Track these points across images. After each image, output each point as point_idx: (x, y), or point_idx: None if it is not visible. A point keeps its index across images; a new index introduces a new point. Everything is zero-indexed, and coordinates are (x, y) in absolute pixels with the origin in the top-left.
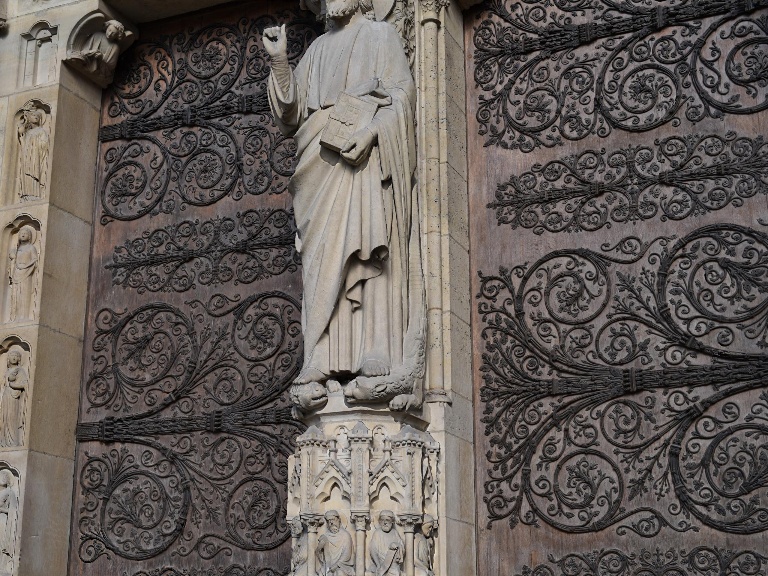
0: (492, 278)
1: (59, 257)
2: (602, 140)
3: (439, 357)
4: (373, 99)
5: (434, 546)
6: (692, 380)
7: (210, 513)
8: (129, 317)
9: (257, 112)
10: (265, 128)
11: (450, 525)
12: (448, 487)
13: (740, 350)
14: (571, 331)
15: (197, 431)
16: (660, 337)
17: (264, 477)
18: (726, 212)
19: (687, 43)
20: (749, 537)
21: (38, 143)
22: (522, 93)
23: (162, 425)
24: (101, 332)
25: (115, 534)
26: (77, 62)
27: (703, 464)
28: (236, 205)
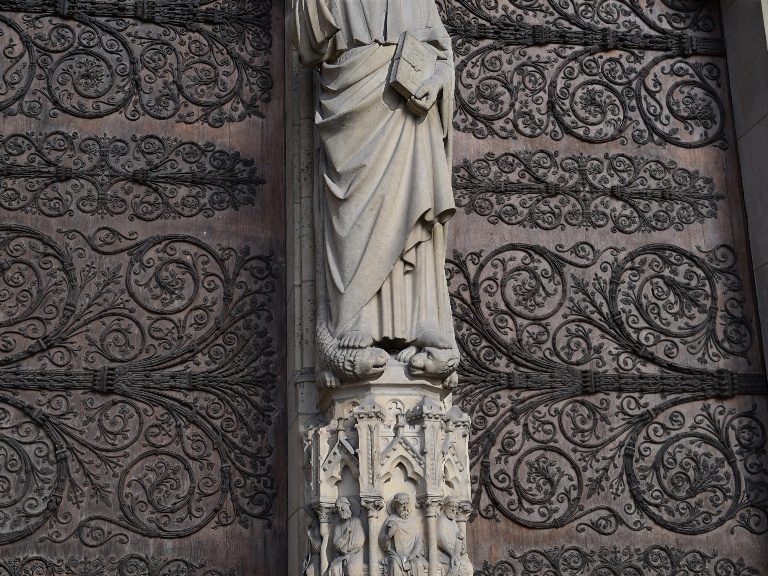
0: (446, 260)
1: None
2: (555, 143)
3: None
4: (433, 49)
5: None
6: (646, 387)
7: (97, 491)
8: None
9: (160, 23)
10: (171, 44)
11: None
12: None
13: (684, 363)
14: (528, 326)
15: (77, 389)
16: (613, 342)
17: (174, 451)
18: (669, 234)
19: (633, 69)
20: (695, 537)
21: None
22: (474, 78)
23: (26, 378)
24: None
25: None
26: None
27: (655, 467)
28: (131, 126)
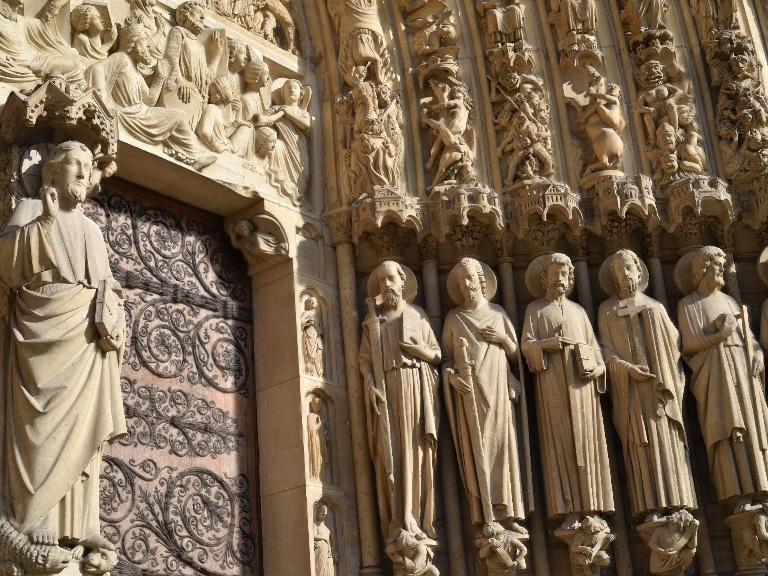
0: None
1: None
2: (135, 372)
3: None
4: (117, 296)
5: None
6: None
7: None
8: None
9: None
10: None
11: None
12: None
13: (211, 568)
14: (106, 527)
15: None
16: (164, 547)
17: None
18: (207, 460)
19: None
20: None
21: None
22: None
23: None
24: None
25: None
26: None
27: None
28: None
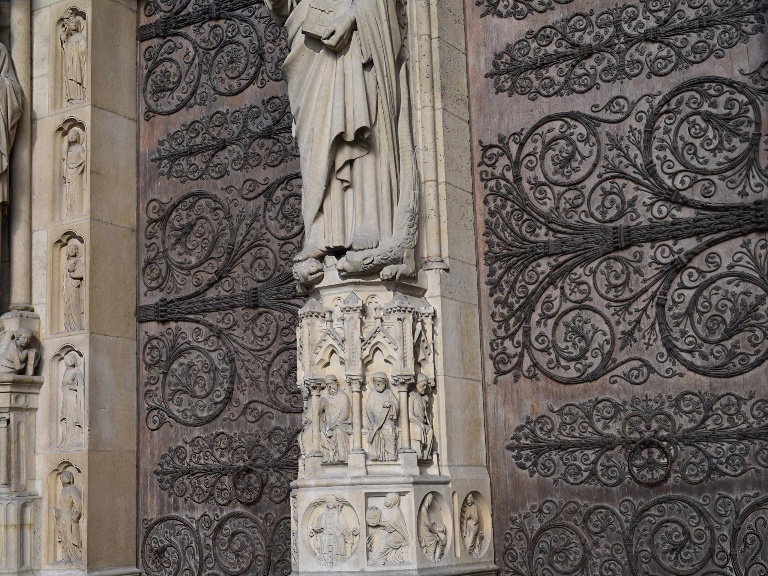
0: (491, 146)
1: (105, 155)
2: (590, 1)
3: (435, 227)
4: None
5: (432, 402)
6: (676, 233)
7: (253, 381)
8: (174, 206)
9: None
10: None
11: (450, 382)
12: (446, 348)
13: (722, 201)
14: (565, 193)
15: (238, 307)
16: (647, 193)
17: None
18: (708, 65)
19: None
20: (730, 380)
21: (78, 49)
22: None
23: (208, 304)
24: (151, 221)
25: (175, 404)
26: None
27: (687, 313)
28: (261, 93)
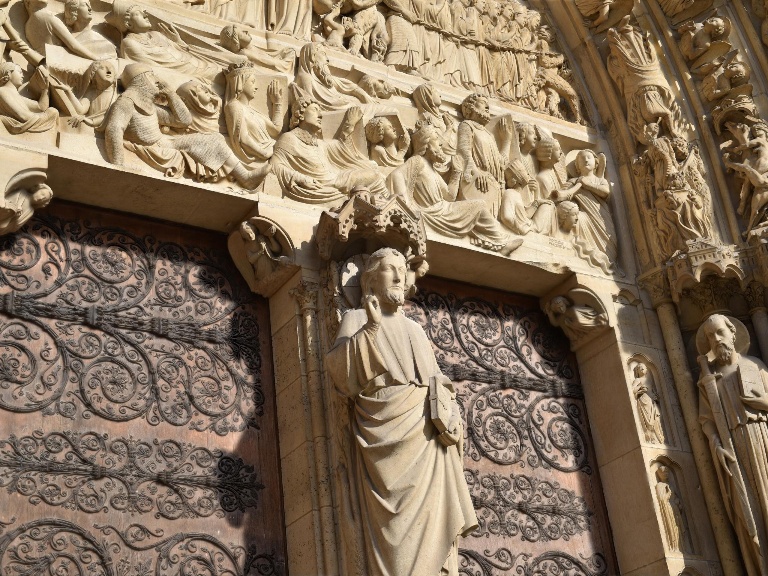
0: None
1: None
2: (475, 463)
3: None
4: None
5: None
6: None
7: None
8: (22, 530)
9: (172, 339)
10: (182, 358)
11: None
12: None
13: None
14: None
15: None
16: None
17: None
18: (560, 543)
19: (523, 405)
20: None
21: None
22: None
23: None
24: None
25: None
26: (8, 214)
27: None
28: (152, 430)
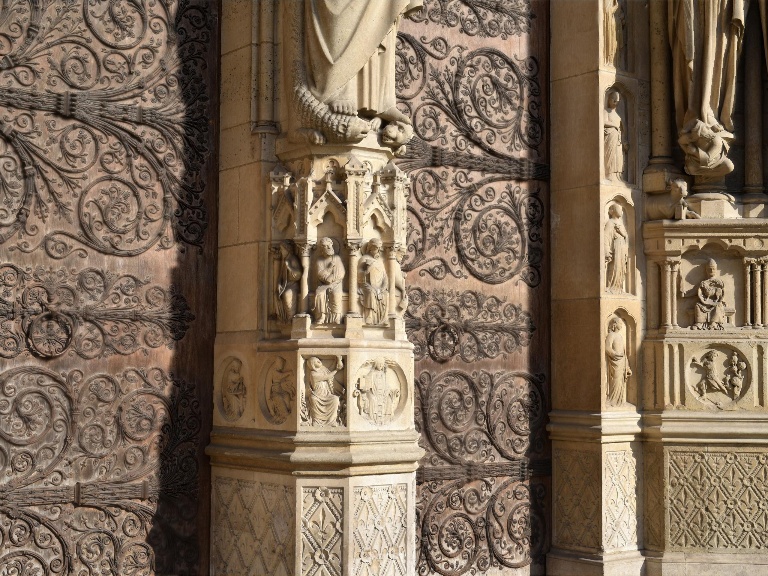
0: None
1: None
2: None
3: None
4: None
5: None
6: None
7: (60, 208)
8: None
9: None
10: None
11: None
12: None
13: (498, 149)
14: (398, 103)
15: (41, 110)
16: (454, 126)
17: (126, 179)
18: (498, 41)
19: None
20: (494, 286)
21: None
22: None
23: None
24: None
25: None
26: None
27: (474, 230)
28: None
